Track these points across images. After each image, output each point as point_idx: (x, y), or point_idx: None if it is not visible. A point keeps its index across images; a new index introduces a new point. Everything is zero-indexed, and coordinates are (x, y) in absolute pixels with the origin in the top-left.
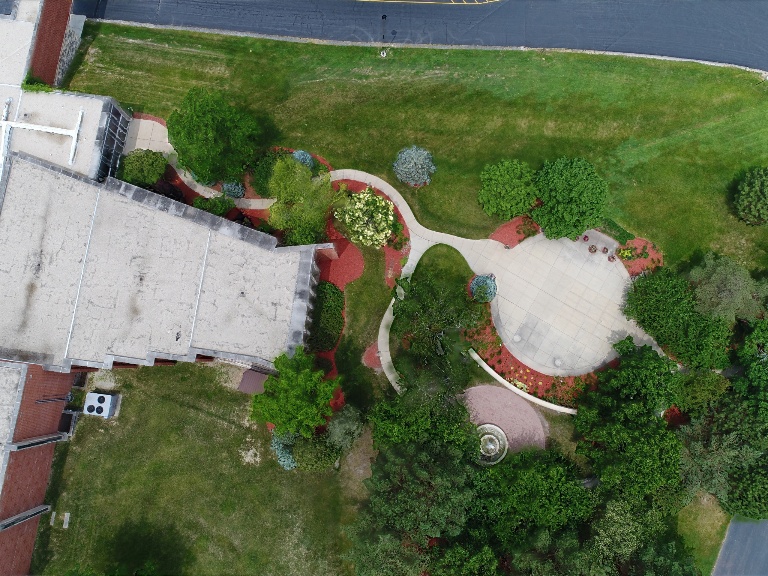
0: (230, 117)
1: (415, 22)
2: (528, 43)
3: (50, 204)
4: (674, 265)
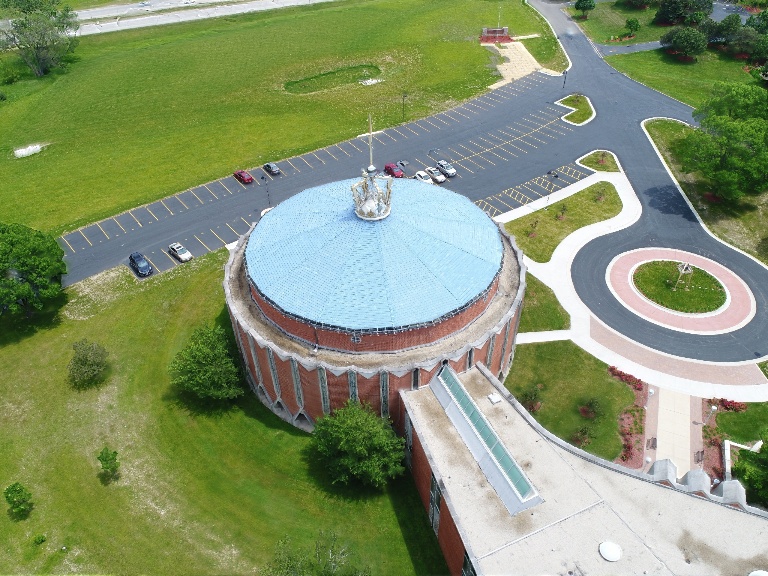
0: None
1: None
2: None
3: None
4: None
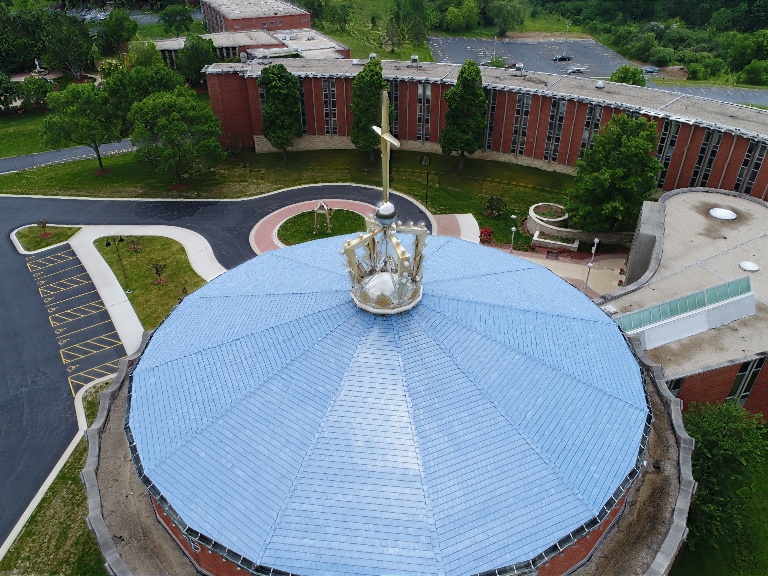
0: (184, 46)
1: (118, 145)
2: (30, 155)
3: None
4: None
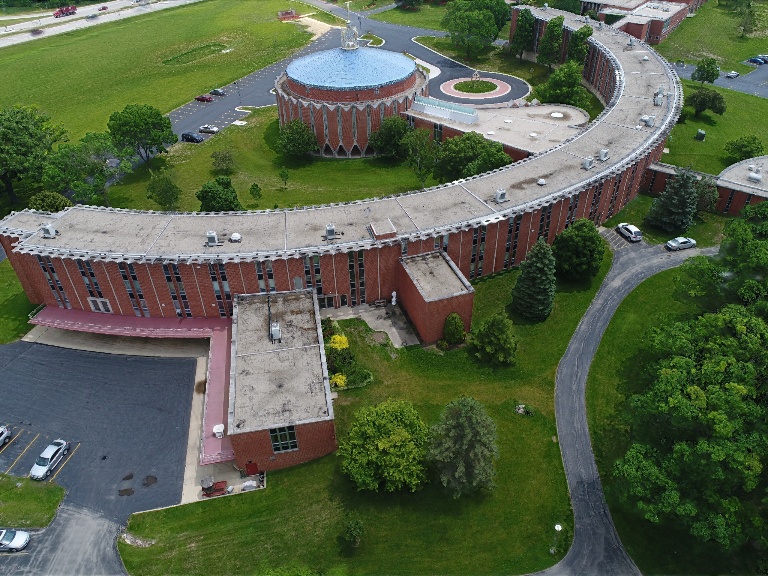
0: None
1: None
2: None
3: (621, 5)
4: (444, 7)
